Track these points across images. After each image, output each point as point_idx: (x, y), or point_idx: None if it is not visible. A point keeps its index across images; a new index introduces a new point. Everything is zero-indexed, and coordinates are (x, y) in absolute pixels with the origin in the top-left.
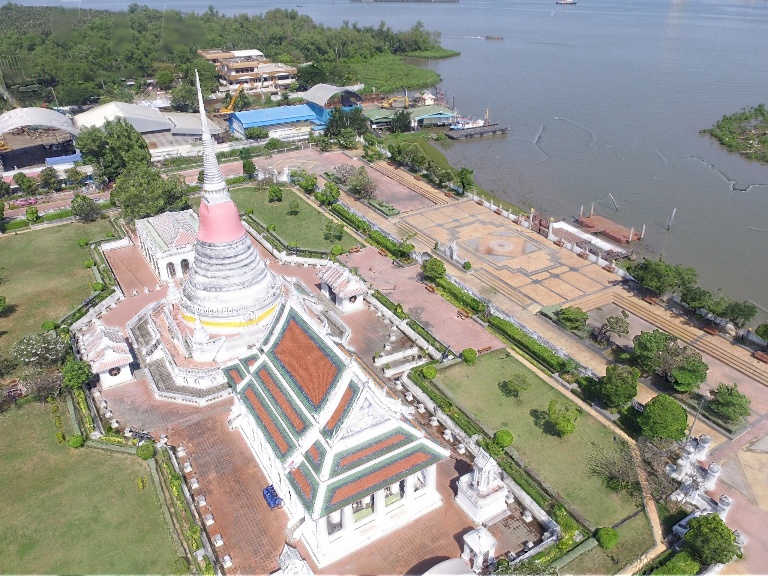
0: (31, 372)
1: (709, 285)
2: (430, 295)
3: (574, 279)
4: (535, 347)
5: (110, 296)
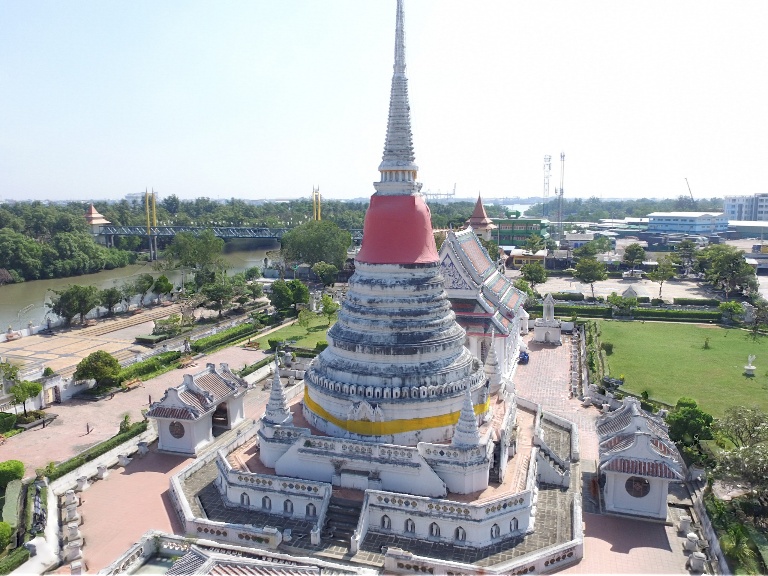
0: (762, 413)
1: (108, 284)
2: (149, 385)
3: (49, 346)
4: (235, 330)
5: None
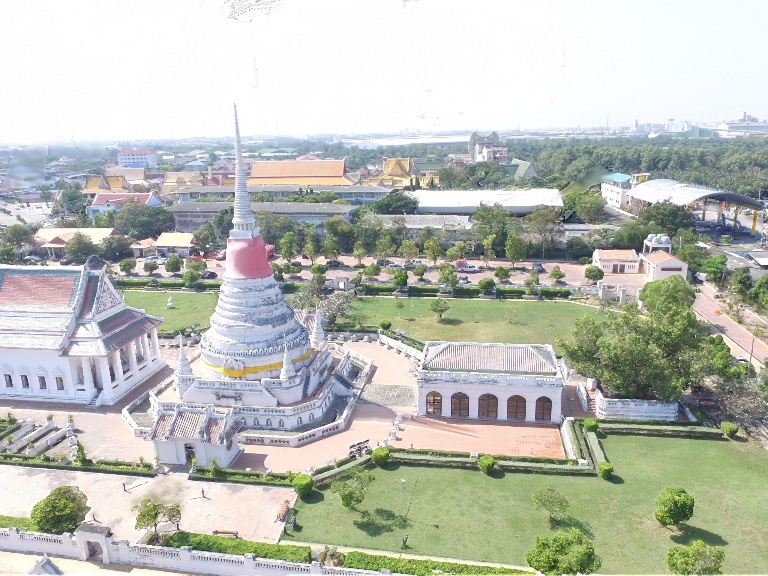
0: (292, 298)
1: None
2: None
3: None
4: None
5: (417, 350)
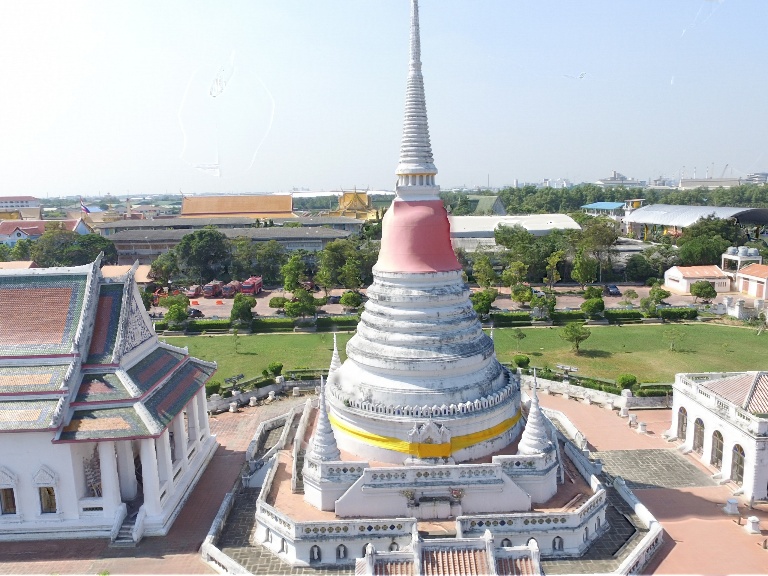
0: None
1: None
2: None
3: None
4: None
5: (607, 393)
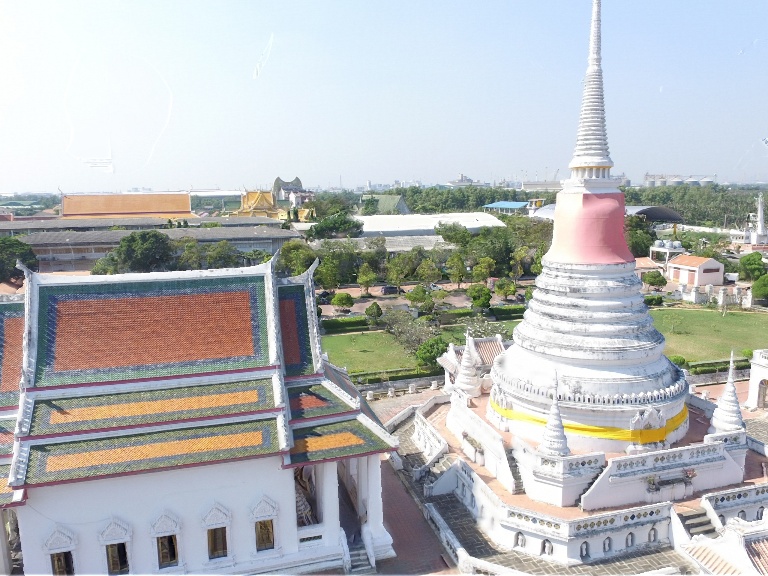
0: (425, 327)
1: None
2: None
3: None
4: None
5: None
